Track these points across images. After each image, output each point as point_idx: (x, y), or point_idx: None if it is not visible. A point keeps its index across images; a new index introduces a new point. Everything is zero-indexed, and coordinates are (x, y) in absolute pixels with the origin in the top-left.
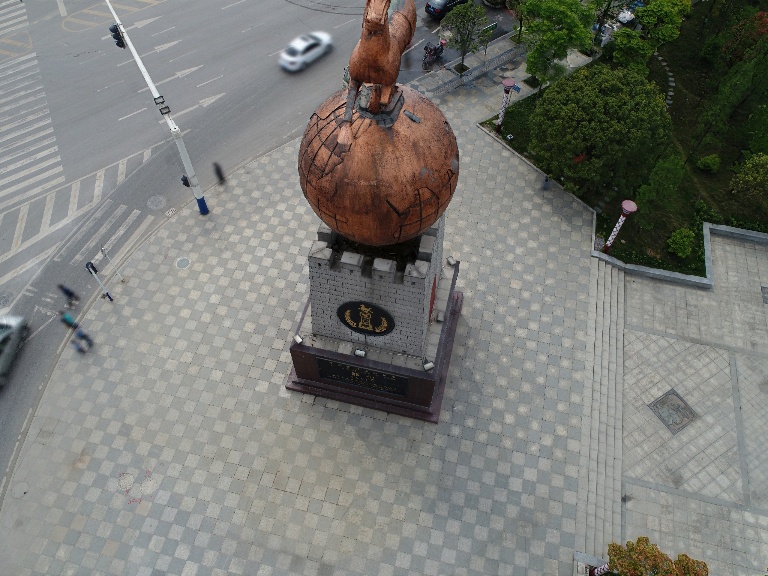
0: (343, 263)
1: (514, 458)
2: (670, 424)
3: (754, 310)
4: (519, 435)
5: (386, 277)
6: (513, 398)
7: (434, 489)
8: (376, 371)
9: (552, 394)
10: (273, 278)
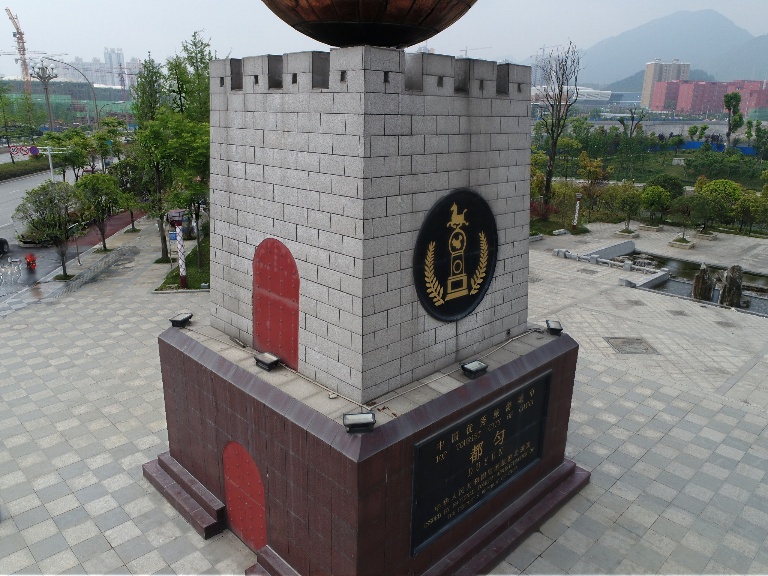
0: (428, 54)
1: (681, 437)
2: (646, 352)
3: (537, 287)
4: (641, 420)
5: (487, 82)
6: (575, 403)
7: (735, 538)
8: (513, 392)
9: (584, 378)
10: (27, 569)
